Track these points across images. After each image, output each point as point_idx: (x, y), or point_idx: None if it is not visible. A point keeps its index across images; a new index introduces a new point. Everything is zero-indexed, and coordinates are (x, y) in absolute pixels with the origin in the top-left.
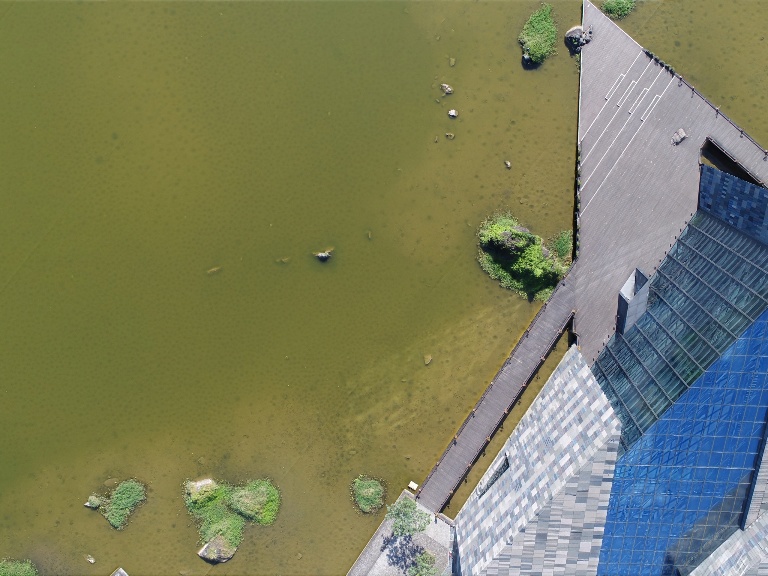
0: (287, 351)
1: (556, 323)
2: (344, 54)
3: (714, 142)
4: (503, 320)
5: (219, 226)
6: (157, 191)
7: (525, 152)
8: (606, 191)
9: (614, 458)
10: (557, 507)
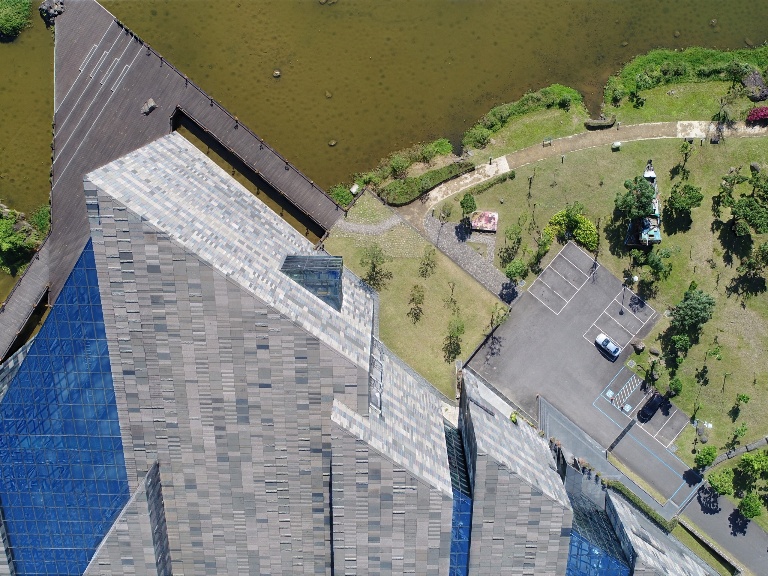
0: None
1: (32, 297)
2: None
3: (184, 111)
4: None
5: None
6: None
7: (4, 126)
8: (77, 163)
9: None
10: None
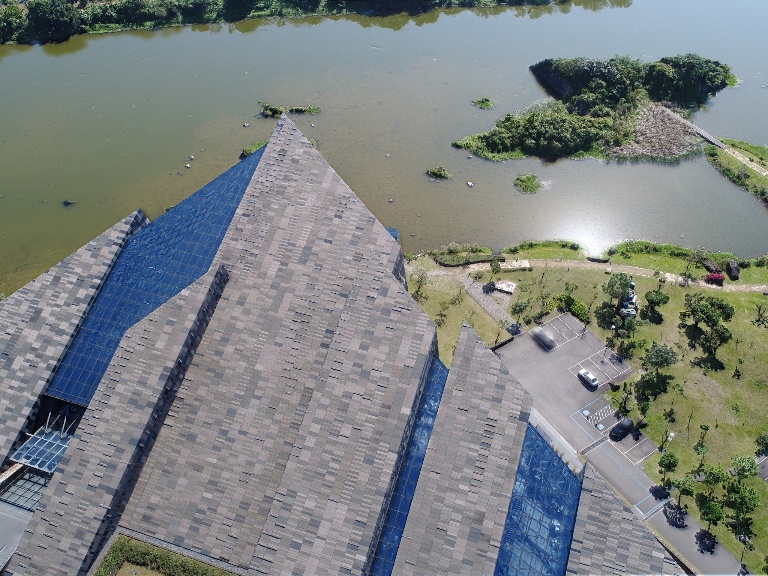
0: (7, 237)
1: None
2: (149, 138)
3: None
4: None
5: (23, 181)
6: (4, 163)
7: None
8: None
9: (127, 229)
10: (77, 258)
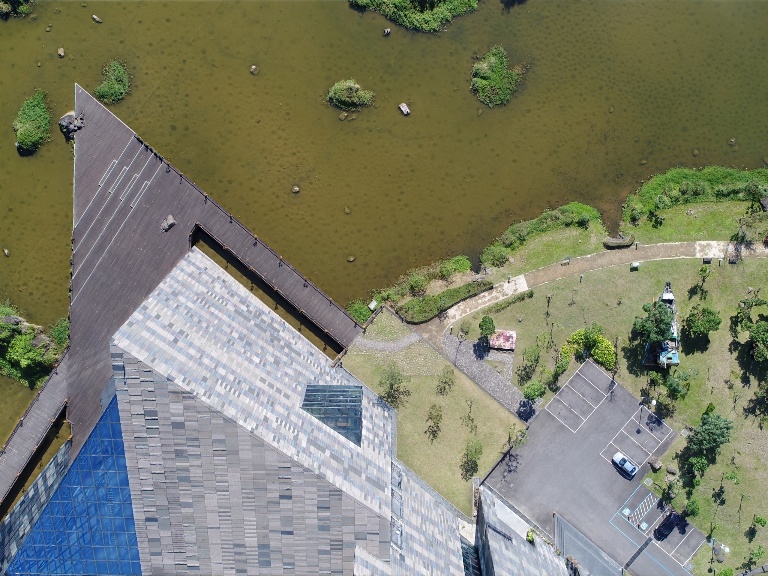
0: None
1: (50, 412)
2: None
3: (203, 228)
4: (5, 408)
5: None
6: None
7: (23, 239)
8: (96, 279)
9: None
10: None
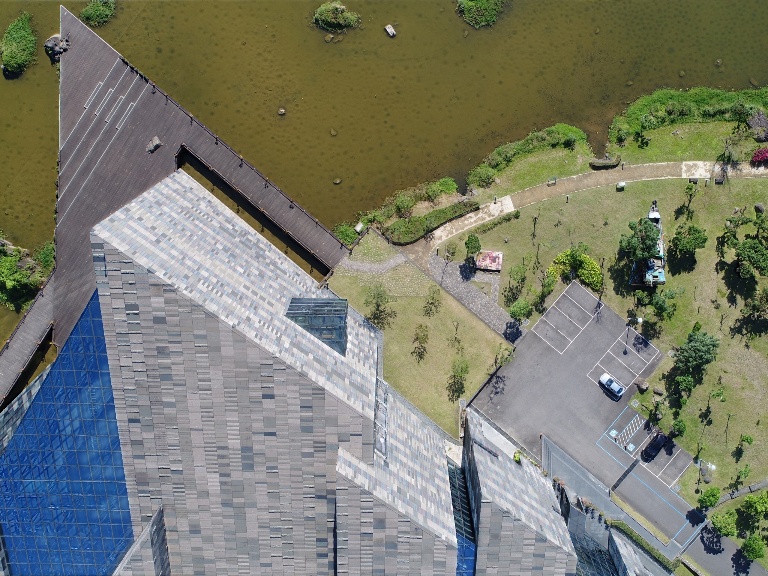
0: None
1: (36, 334)
2: None
3: (189, 149)
4: None
5: None
6: None
7: (9, 163)
8: (82, 201)
9: None
10: None
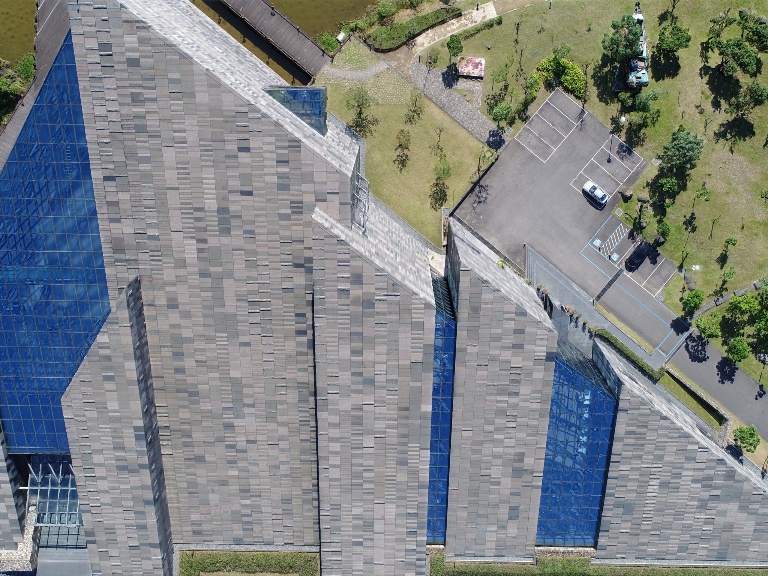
0: None
1: None
2: None
3: None
4: None
5: None
6: None
7: None
8: (62, 9)
9: None
10: None
